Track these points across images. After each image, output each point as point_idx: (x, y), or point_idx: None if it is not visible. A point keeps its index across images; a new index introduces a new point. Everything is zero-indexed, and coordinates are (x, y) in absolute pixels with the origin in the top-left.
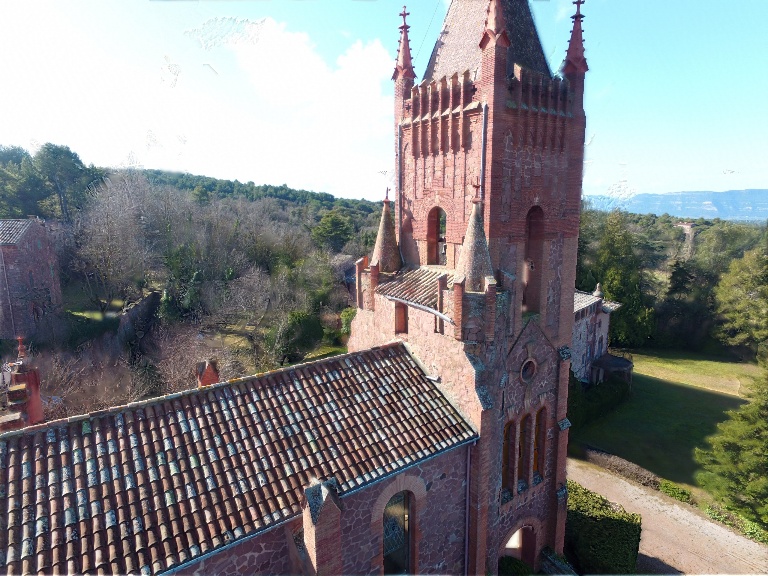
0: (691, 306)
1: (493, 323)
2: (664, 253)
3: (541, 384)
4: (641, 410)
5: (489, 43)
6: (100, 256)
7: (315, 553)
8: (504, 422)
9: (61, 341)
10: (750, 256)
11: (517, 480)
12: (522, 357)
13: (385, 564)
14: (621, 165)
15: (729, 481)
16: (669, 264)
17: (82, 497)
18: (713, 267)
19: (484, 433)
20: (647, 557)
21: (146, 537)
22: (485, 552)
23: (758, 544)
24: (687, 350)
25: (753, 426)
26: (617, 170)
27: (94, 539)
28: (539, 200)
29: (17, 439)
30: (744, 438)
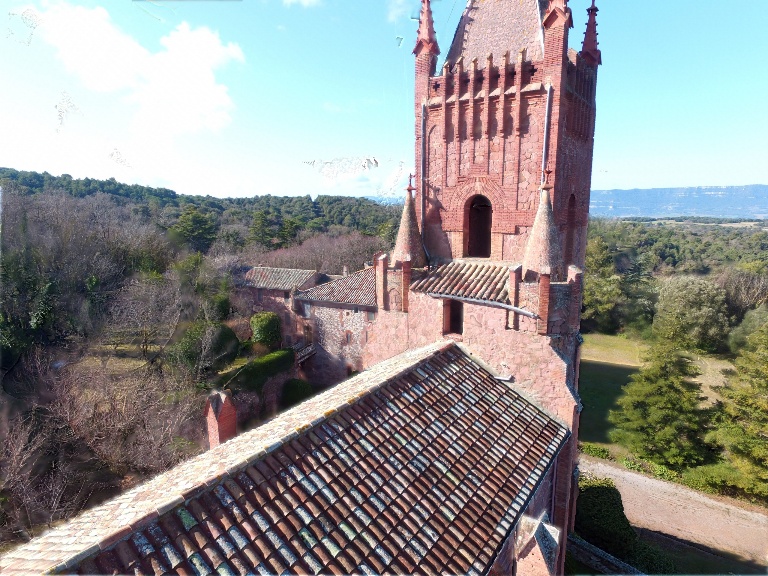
0: None
1: (577, 313)
2: None
3: None
4: None
5: (556, 22)
6: None
7: None
8: None
9: None
10: (593, 243)
11: None
12: None
13: None
14: None
15: (642, 434)
16: None
17: None
18: None
19: (573, 428)
20: None
21: None
22: None
23: (667, 483)
24: None
25: (655, 385)
26: None
27: None
28: (574, 188)
29: (93, 563)
30: (649, 396)
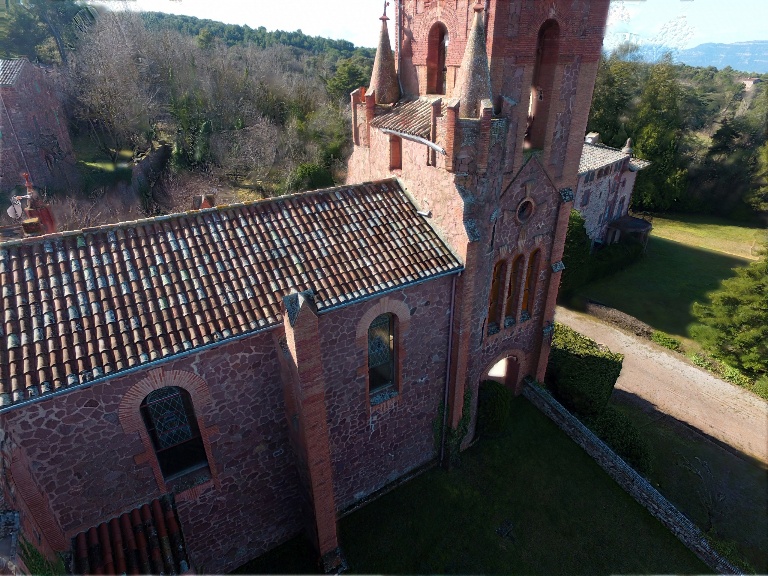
0: (729, 168)
1: (486, 152)
2: (712, 107)
3: (538, 226)
4: (651, 270)
5: None
6: (101, 101)
7: (295, 352)
8: (495, 260)
9: (77, 189)
10: None
11: (505, 316)
12: (520, 196)
13: (371, 375)
14: None
15: (720, 332)
16: (715, 120)
17: (82, 298)
18: (764, 124)
19: (469, 265)
20: (626, 392)
21: (143, 332)
22: (465, 372)
23: (734, 386)
24: (714, 215)
25: (757, 282)
26: (678, 3)
27: (96, 331)
28: (556, 11)
29: (17, 248)
30: (745, 293)
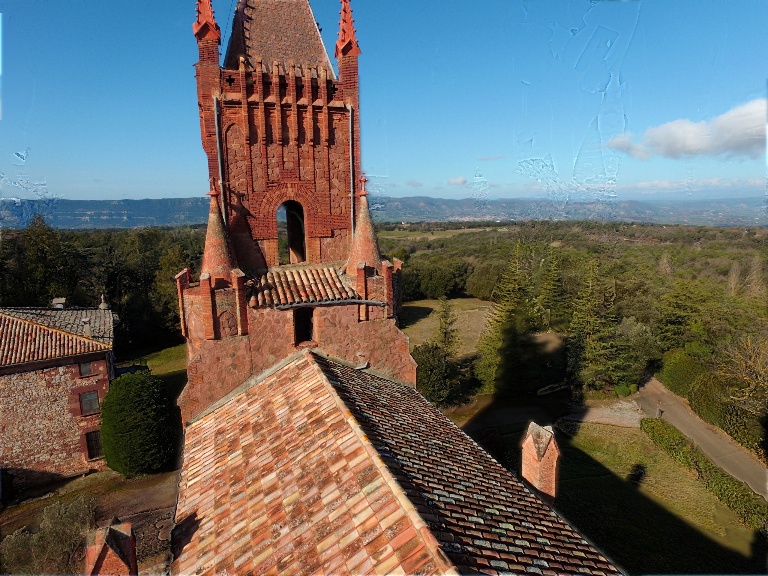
0: (135, 305)
1: None
2: (98, 260)
3: None
4: None
5: (351, 51)
6: None
7: None
8: None
9: None
10: (174, 253)
11: None
12: None
13: None
14: (17, 166)
15: None
16: (101, 270)
17: None
18: (144, 267)
19: None
20: None
21: (590, 567)
22: None
23: None
24: (142, 347)
25: None
26: (13, 171)
27: None
28: None
29: None
30: None
